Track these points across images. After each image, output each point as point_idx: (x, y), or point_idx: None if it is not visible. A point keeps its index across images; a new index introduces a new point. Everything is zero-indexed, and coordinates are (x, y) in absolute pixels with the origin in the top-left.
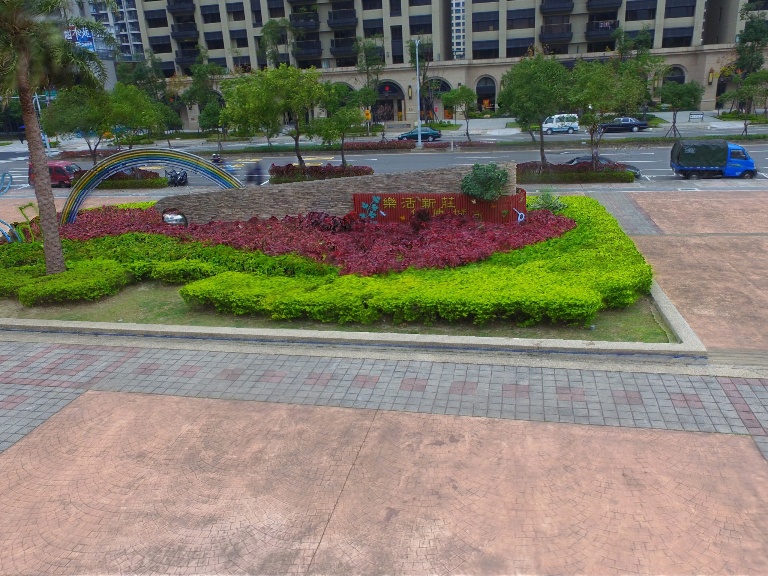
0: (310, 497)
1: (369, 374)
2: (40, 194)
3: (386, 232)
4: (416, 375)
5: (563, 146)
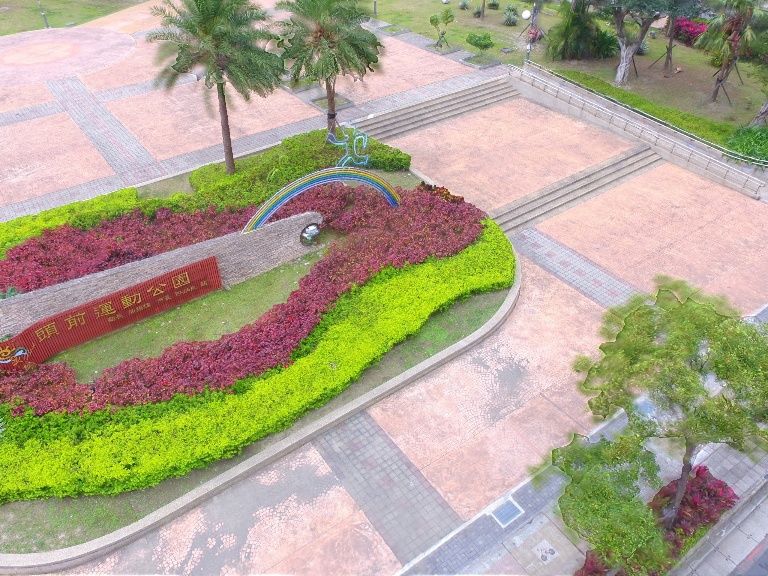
0: (7, 185)
1: (21, 212)
2: None
3: None
4: None
5: None
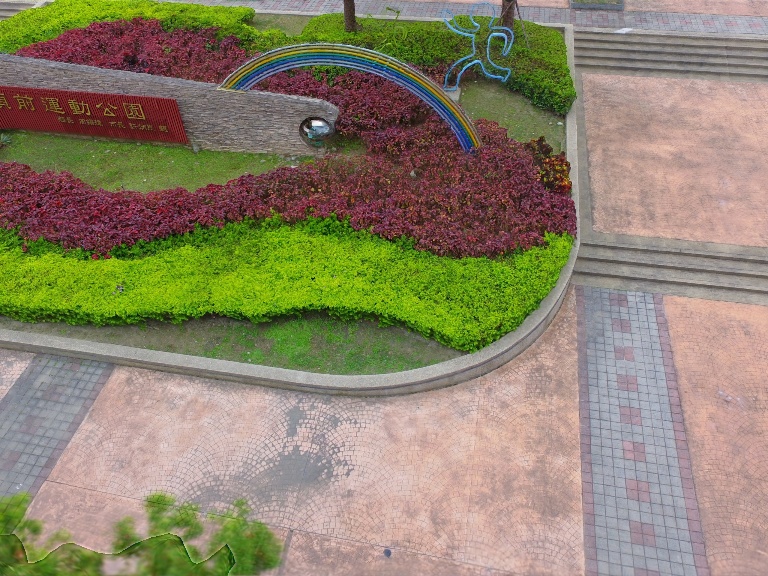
0: None
1: (172, 0)
2: None
3: None
4: (155, 0)
5: None
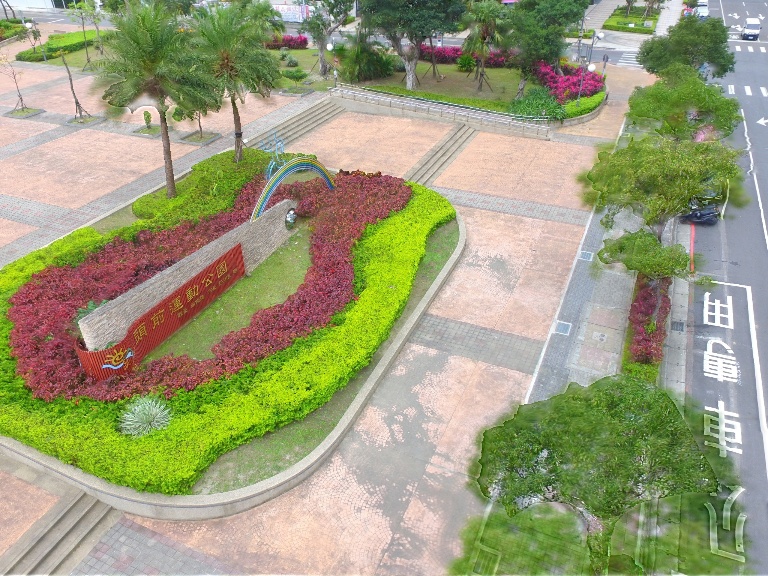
0: None
1: None
2: None
3: None
4: None
5: None
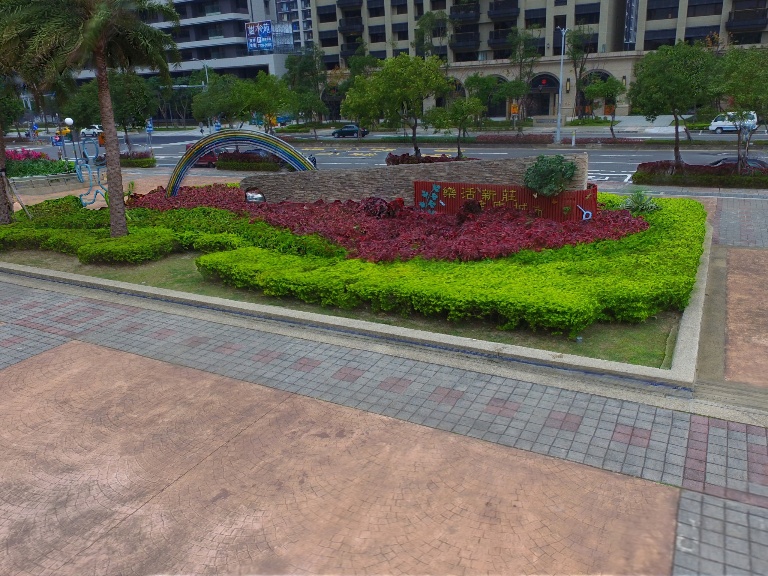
0: (165, 465)
1: (314, 358)
2: (108, 164)
3: (428, 221)
4: (358, 365)
5: (723, 146)
